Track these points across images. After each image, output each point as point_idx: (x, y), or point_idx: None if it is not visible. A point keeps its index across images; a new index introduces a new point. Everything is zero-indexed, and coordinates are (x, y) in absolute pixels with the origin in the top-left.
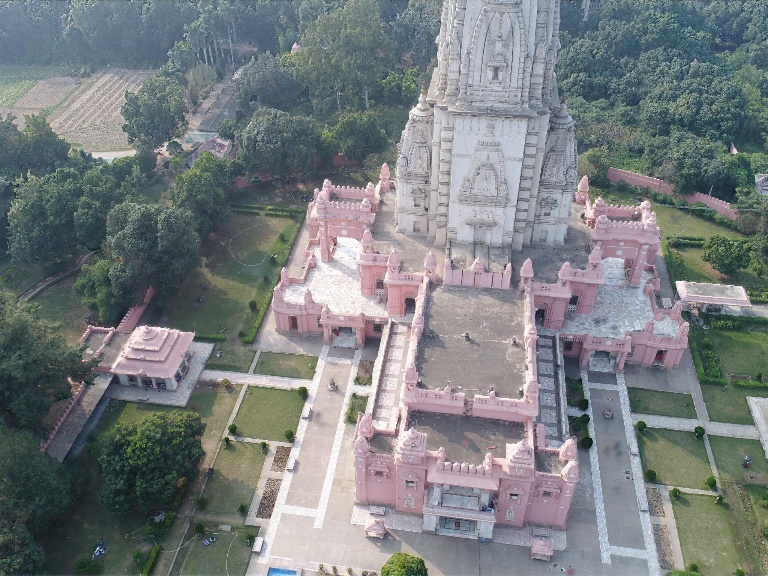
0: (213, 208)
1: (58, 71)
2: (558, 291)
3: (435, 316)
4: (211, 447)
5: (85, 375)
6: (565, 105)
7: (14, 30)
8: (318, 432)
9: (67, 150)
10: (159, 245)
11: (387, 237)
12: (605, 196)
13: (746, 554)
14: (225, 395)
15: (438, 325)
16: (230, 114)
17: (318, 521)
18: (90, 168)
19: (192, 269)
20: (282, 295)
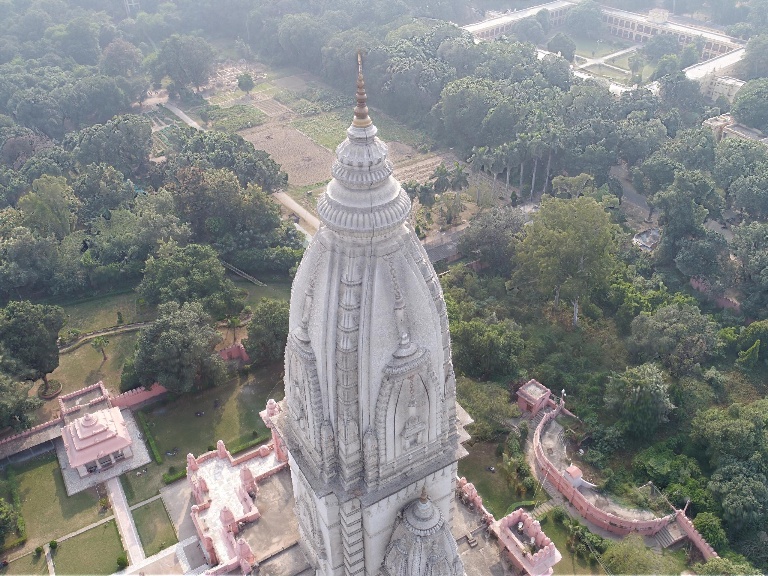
0: (269, 342)
1: (412, 138)
2: None
3: None
4: (32, 545)
5: (24, 422)
6: (425, 504)
7: (399, 92)
8: None
9: (273, 223)
10: (153, 355)
11: (291, 484)
12: None
13: None
14: (95, 511)
15: None
16: (453, 249)
17: None
18: (284, 245)
19: (180, 388)
20: (205, 463)
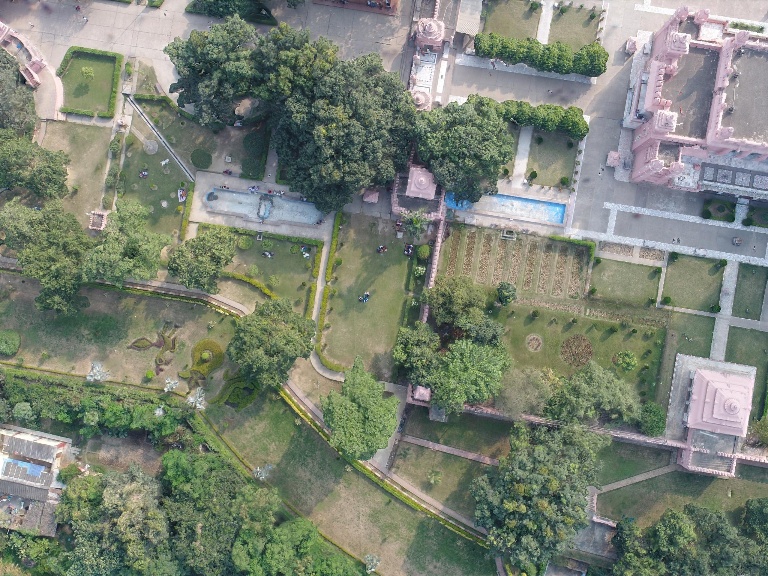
0: None
1: None
2: None
3: None
4: None
5: None
6: None
7: None
8: (723, 1)
9: None
10: None
11: None
12: None
13: (609, 303)
14: None
15: None
16: None
17: (641, 6)
18: None
19: None
20: None
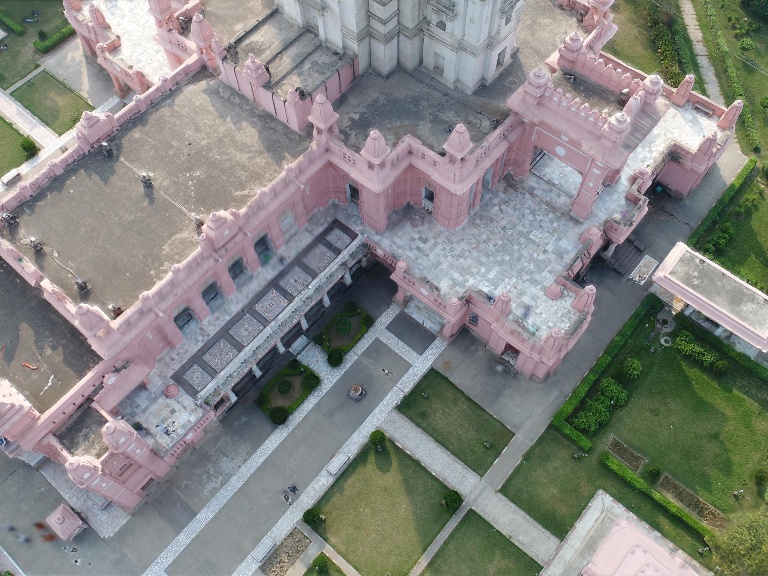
0: None
1: None
2: (364, 172)
3: (149, 124)
4: None
5: None
6: None
7: None
8: None
9: None
10: None
11: None
12: (745, 35)
13: None
14: None
15: (137, 141)
16: None
17: None
18: None
19: None
20: None
